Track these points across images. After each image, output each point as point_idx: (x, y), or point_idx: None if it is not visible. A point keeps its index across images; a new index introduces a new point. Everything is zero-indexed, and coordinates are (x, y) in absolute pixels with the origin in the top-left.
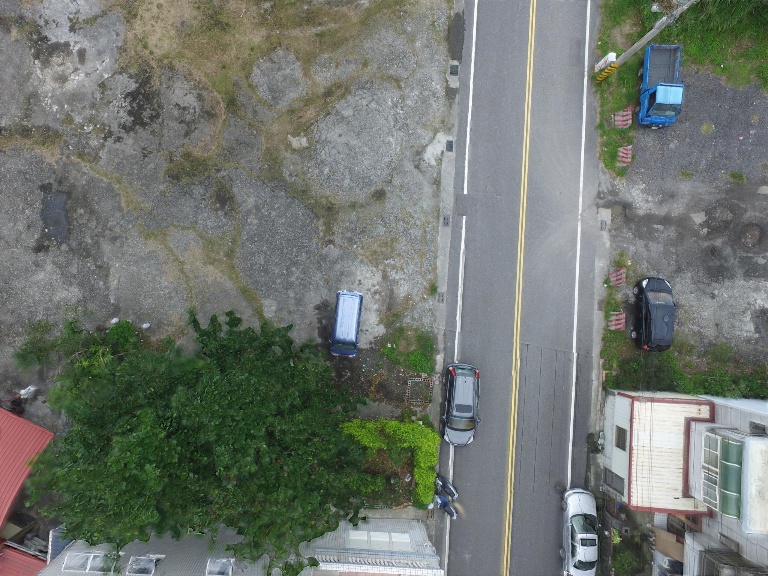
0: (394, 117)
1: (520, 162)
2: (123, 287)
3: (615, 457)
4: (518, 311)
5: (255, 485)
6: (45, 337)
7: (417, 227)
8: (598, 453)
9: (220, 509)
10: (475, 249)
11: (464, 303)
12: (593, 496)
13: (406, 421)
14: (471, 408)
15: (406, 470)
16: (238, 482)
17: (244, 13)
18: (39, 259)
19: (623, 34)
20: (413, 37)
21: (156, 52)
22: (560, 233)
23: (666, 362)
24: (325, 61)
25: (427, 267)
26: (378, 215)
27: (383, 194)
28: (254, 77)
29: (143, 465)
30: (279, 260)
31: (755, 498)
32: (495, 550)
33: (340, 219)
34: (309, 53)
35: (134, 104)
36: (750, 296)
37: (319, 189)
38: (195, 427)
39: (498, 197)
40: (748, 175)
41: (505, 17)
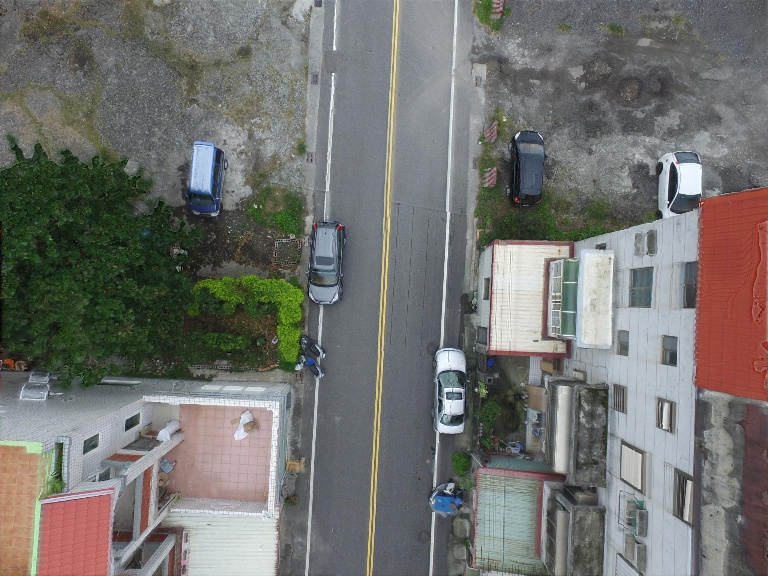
0: None
1: (391, 16)
2: None
3: (483, 311)
4: (388, 169)
5: (45, 283)
6: None
7: (284, 85)
8: (472, 313)
9: None
10: (345, 107)
11: (333, 162)
12: (463, 353)
13: None
14: (332, 260)
15: (273, 332)
16: (15, 270)
17: None
18: None
19: None
20: None
21: None
22: (433, 89)
23: (541, 219)
24: None
25: (295, 126)
26: (244, 73)
27: (249, 52)
28: None
29: None
30: (141, 120)
31: (590, 312)
32: (365, 412)
33: (204, 78)
34: None
35: None
36: (628, 151)
37: (182, 47)
38: None
39: (368, 53)
40: (627, 27)
41: None
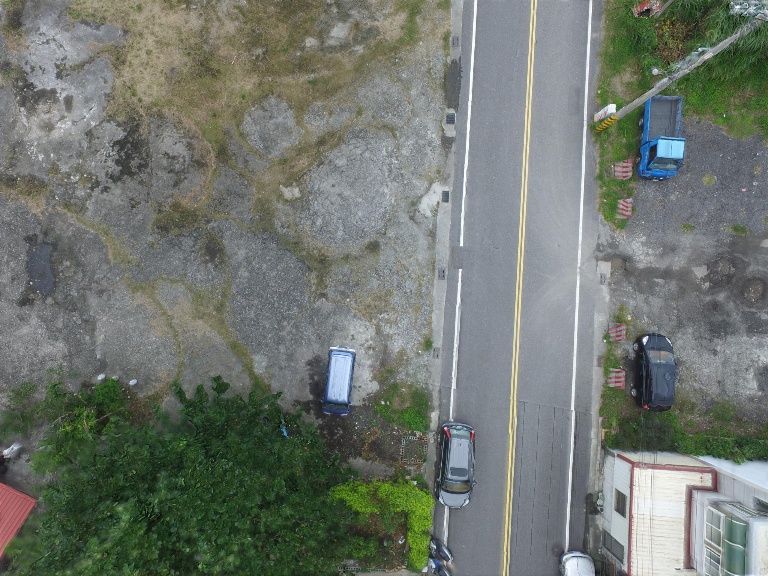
0: (389, 167)
1: (518, 214)
2: (110, 342)
3: (614, 521)
4: (515, 368)
5: None
6: (29, 393)
7: (412, 280)
8: (597, 514)
9: None
10: (471, 303)
11: (460, 359)
12: (592, 560)
13: (400, 482)
14: (466, 471)
15: (400, 532)
16: None
17: (235, 60)
18: (23, 313)
19: (623, 82)
20: (408, 85)
21: (145, 100)
22: (558, 287)
23: (667, 421)
24: (318, 109)
25: (422, 322)
26: (372, 268)
27: (377, 246)
28: (245, 125)
29: (121, 565)
30: (270, 314)
31: None
32: None
33: (333, 272)
34: (302, 101)
35: (122, 153)
36: (753, 353)
37: (311, 241)
38: (178, 515)
39: (495, 250)
40: (751, 228)
41: (503, 65)
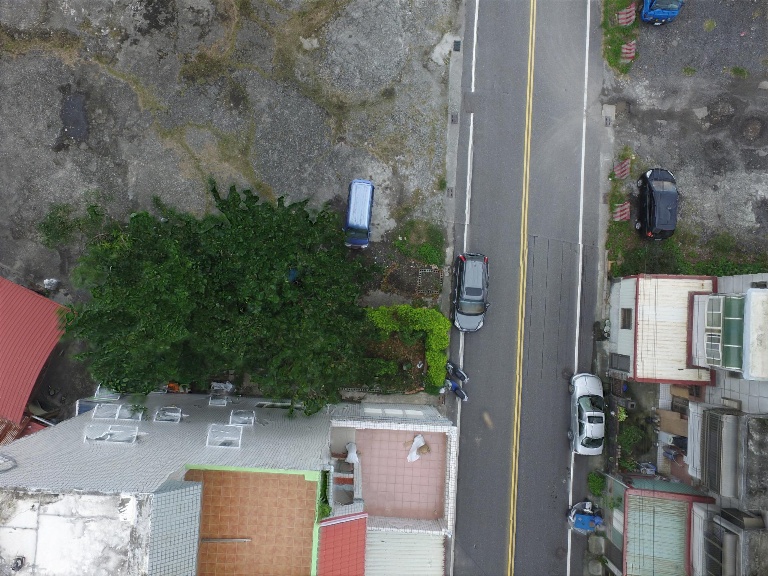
0: (403, 18)
1: (526, 60)
2: (141, 184)
3: (621, 339)
4: (525, 203)
5: (278, 321)
6: (66, 232)
7: (426, 124)
8: (604, 340)
9: (246, 329)
10: (483, 145)
11: (473, 197)
12: (599, 379)
13: None
14: (481, 291)
15: (418, 357)
16: (262, 310)
17: None
18: (59, 158)
19: None
20: None
21: None
22: (566, 129)
23: (670, 251)
24: None
25: (436, 163)
26: (388, 113)
27: (393, 93)
28: None
29: (172, 290)
30: (292, 157)
31: (757, 347)
32: (505, 433)
33: (351, 117)
34: None
35: (149, 7)
36: (751, 188)
37: (330, 88)
38: (219, 270)
39: (505, 94)
40: (749, 71)
41: None
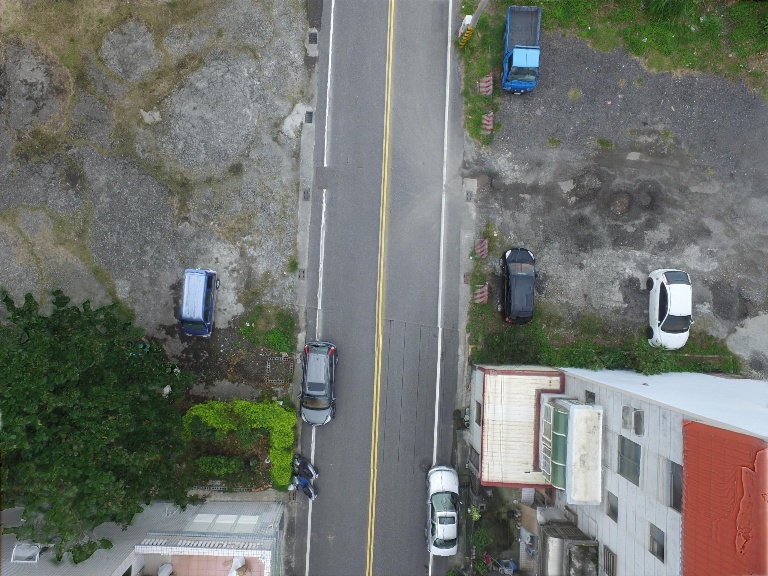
0: (251, 88)
1: (381, 132)
2: None
3: (475, 433)
4: (380, 286)
5: (35, 466)
6: None
7: (276, 202)
8: (464, 430)
9: None
10: (336, 223)
11: (325, 279)
12: (456, 473)
13: (264, 401)
14: (324, 386)
15: (266, 452)
16: (4, 462)
17: None
18: None
19: None
20: (269, 4)
21: (0, 25)
22: (424, 205)
23: (532, 335)
24: (178, 31)
25: (286, 243)
26: (235, 190)
27: (240, 169)
28: (104, 49)
29: None
30: (133, 239)
31: (580, 468)
32: (359, 531)
33: (196, 195)
34: (161, 23)
35: None
36: (619, 265)
37: (174, 165)
38: None
39: (359, 169)
40: (617, 141)
41: None
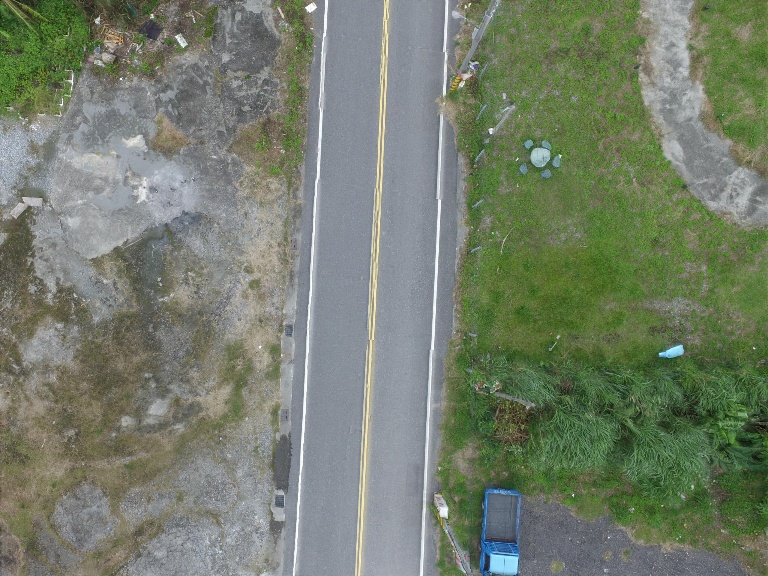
0: (212, 558)
1: None
2: None
3: None
4: None
5: None
6: None
7: None
8: None
9: None
10: None
11: None
12: None
13: None
14: None
15: None
16: None
17: (45, 442)
18: None
19: (465, 458)
20: (233, 465)
21: None
22: None
23: None
24: (135, 496)
25: None
26: None
27: None
28: (56, 516)
29: None
30: None
31: None
32: None
33: None
34: (118, 487)
35: None
36: None
37: None
38: None
39: None
40: None
41: (335, 442)
